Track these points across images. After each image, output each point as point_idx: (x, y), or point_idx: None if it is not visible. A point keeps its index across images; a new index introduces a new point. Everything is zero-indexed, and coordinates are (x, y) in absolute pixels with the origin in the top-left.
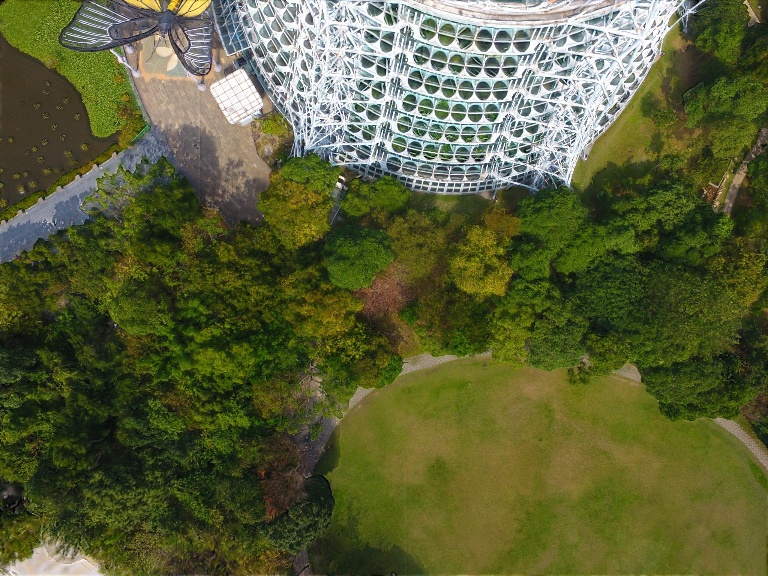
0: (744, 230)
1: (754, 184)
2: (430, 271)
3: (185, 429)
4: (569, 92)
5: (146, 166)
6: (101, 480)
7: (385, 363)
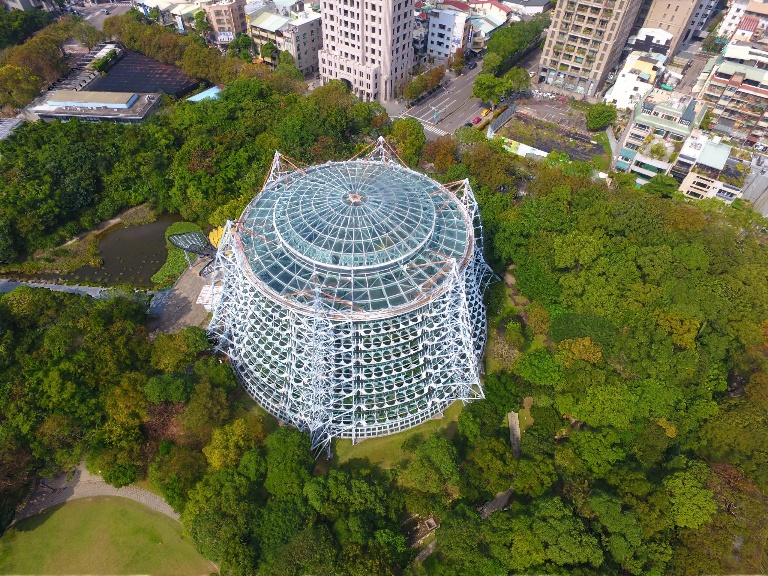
0: (411, 563)
1: None
2: (200, 429)
3: (1, 409)
4: None
5: None
6: None
7: (121, 459)
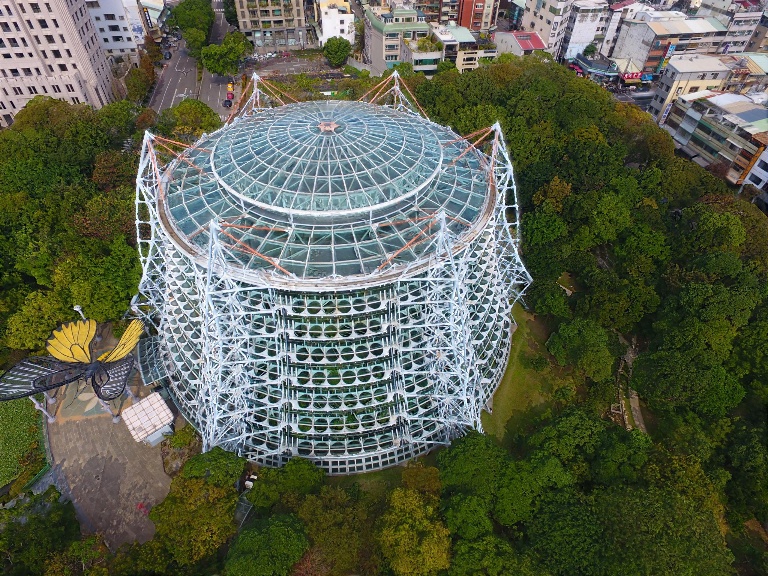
0: (664, 441)
1: (649, 403)
2: (358, 558)
3: None
4: (435, 341)
5: (29, 500)
6: None
7: None
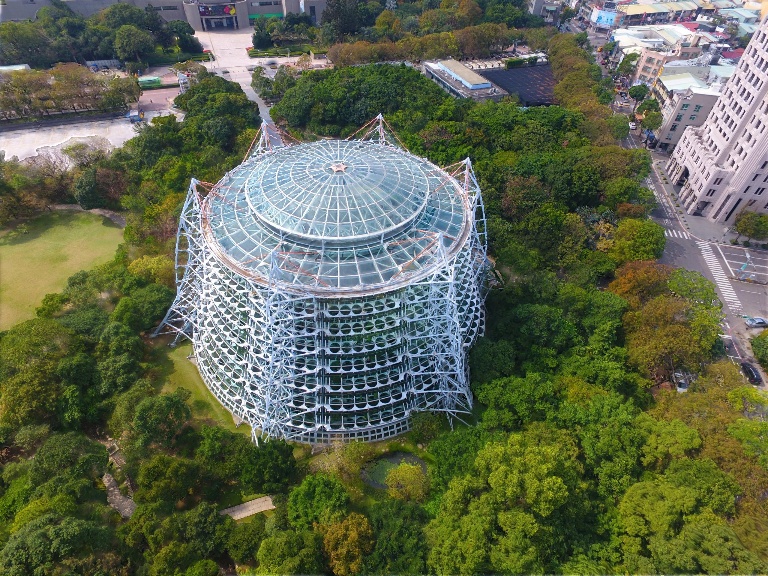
0: (56, 431)
1: None
2: None
3: None
4: None
5: None
6: (156, 138)
7: (133, 223)
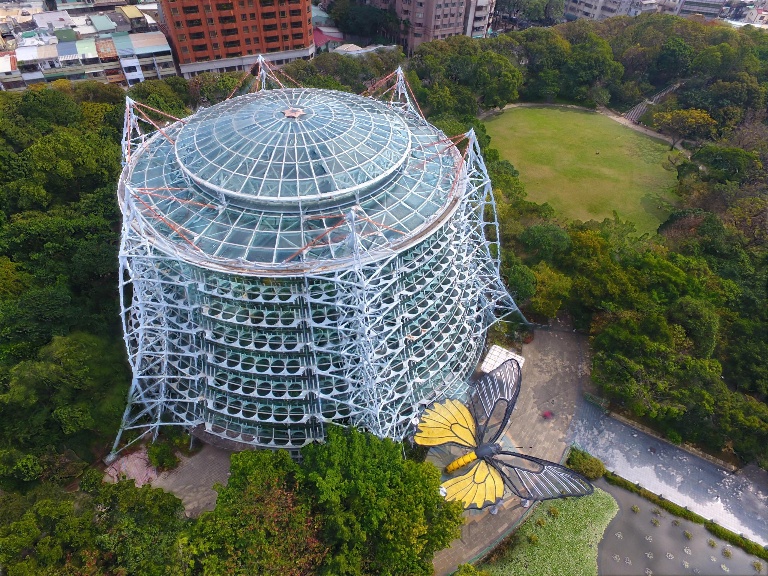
0: None
1: None
2: None
3: None
4: None
5: None
6: None
7: None
